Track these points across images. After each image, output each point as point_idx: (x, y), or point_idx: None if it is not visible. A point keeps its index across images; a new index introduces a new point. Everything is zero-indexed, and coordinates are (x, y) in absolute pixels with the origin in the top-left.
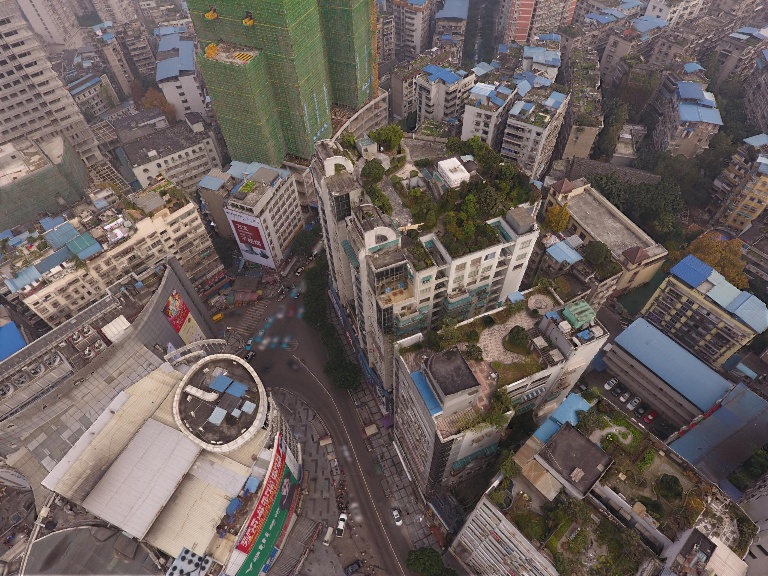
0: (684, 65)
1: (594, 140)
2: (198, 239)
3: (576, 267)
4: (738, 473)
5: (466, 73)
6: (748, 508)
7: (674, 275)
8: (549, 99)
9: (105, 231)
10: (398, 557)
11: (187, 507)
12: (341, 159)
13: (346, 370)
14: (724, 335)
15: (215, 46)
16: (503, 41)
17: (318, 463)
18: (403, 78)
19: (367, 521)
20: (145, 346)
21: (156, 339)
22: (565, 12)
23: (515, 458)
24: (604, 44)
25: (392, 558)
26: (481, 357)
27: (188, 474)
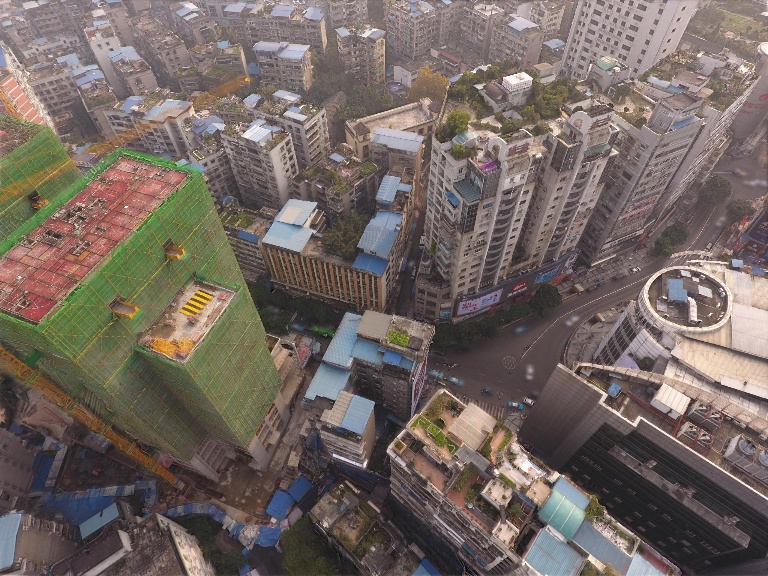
0: (218, 47)
1: None
2: None
3: None
4: None
5: (184, 160)
6: None
7: None
8: (286, 98)
9: (534, 480)
10: None
11: None
12: None
13: (548, 292)
14: None
15: None
16: None
17: None
18: None
19: None
20: None
21: None
22: None
23: None
24: None
25: None
26: None
27: None
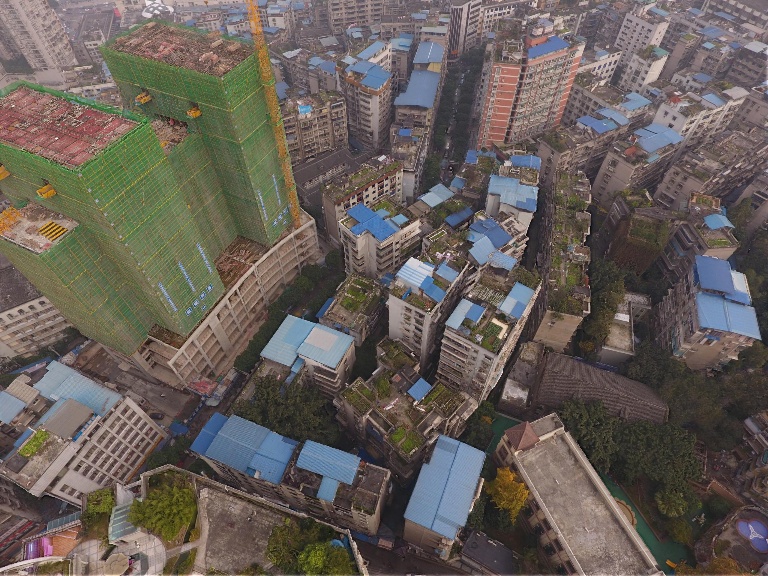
0: (704, 217)
1: None
2: None
3: None
4: None
5: (406, 220)
6: None
7: None
8: (508, 299)
9: None
10: None
11: None
12: None
13: None
14: None
15: (16, 210)
16: (477, 136)
17: None
18: (335, 202)
19: None
20: None
21: None
22: (554, 106)
23: None
24: (601, 154)
25: None
26: None
27: None
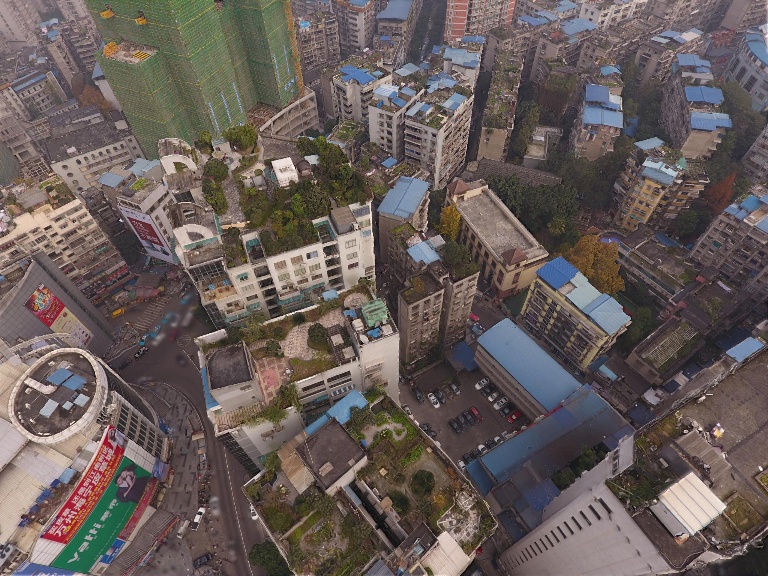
0: (600, 68)
1: (506, 142)
2: (90, 235)
3: (431, 267)
4: (563, 472)
5: (382, 74)
6: (551, 506)
7: (539, 276)
8: (448, 101)
9: None
10: (248, 551)
11: (1, 496)
12: (179, 157)
13: None
14: (583, 337)
15: (115, 45)
16: None
17: (187, 457)
18: (330, 78)
19: (225, 515)
20: (3, 339)
21: (18, 332)
22: (503, 14)
23: (279, 452)
24: None
25: (242, 552)
26: (282, 353)
27: (10, 464)
